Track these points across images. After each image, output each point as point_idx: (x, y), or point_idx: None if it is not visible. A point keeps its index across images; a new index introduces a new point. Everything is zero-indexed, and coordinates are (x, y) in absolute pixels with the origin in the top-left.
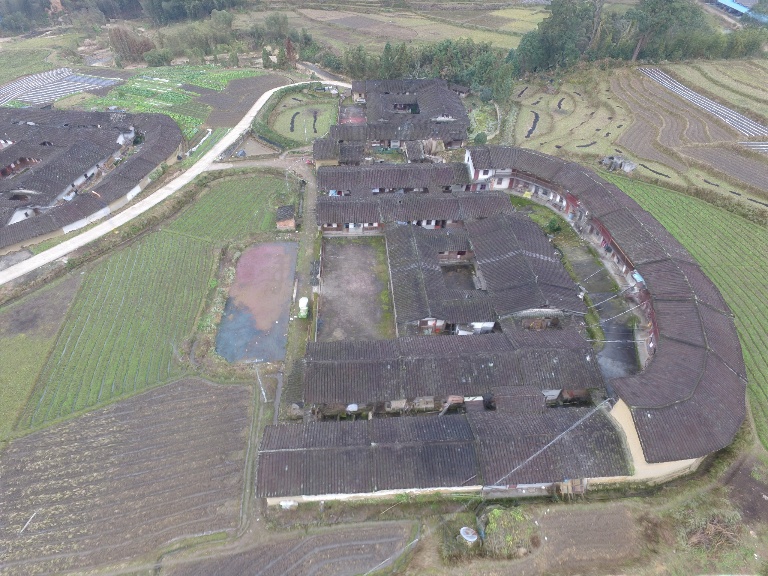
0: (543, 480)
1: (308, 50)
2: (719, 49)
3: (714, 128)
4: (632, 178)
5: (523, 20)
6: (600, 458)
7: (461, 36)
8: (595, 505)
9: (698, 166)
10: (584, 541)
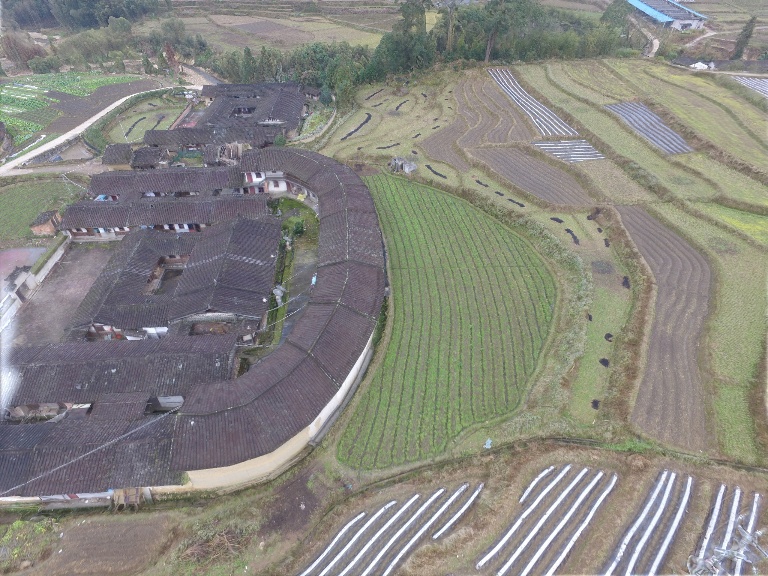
0: (84, 490)
1: (202, 55)
2: (571, 49)
3: (520, 128)
4: (411, 179)
5: (427, 23)
6: (157, 467)
7: (356, 39)
8: (136, 516)
9: (479, 166)
10: (97, 553)
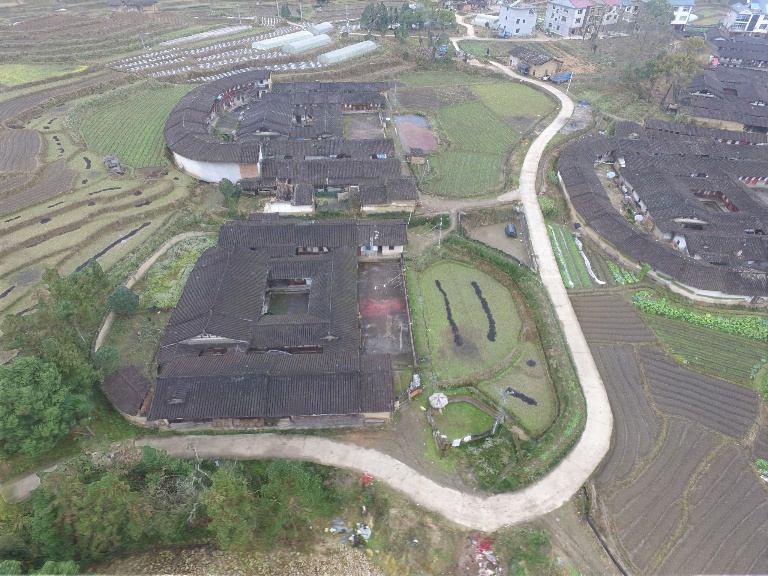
0: None
1: None
2: None
3: None
4: None
5: None
6: None
7: None
8: None
9: None
10: None
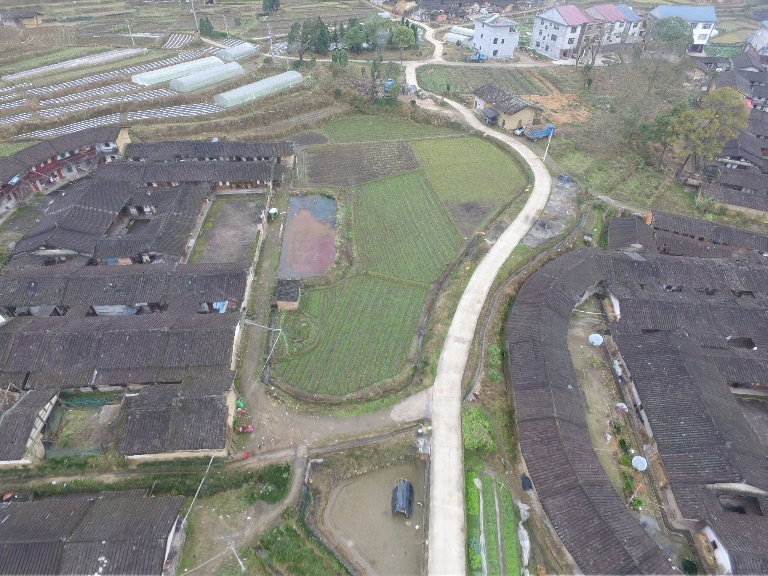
0: None
1: None
2: None
3: None
4: None
5: None
6: None
7: None
8: None
9: None
10: None
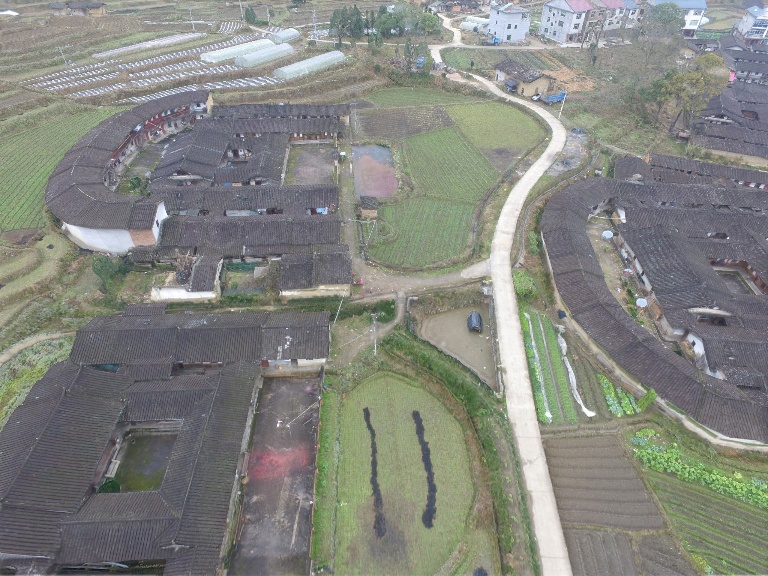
0: None
1: None
2: None
3: None
4: None
5: None
6: None
7: None
8: None
9: None
10: None
